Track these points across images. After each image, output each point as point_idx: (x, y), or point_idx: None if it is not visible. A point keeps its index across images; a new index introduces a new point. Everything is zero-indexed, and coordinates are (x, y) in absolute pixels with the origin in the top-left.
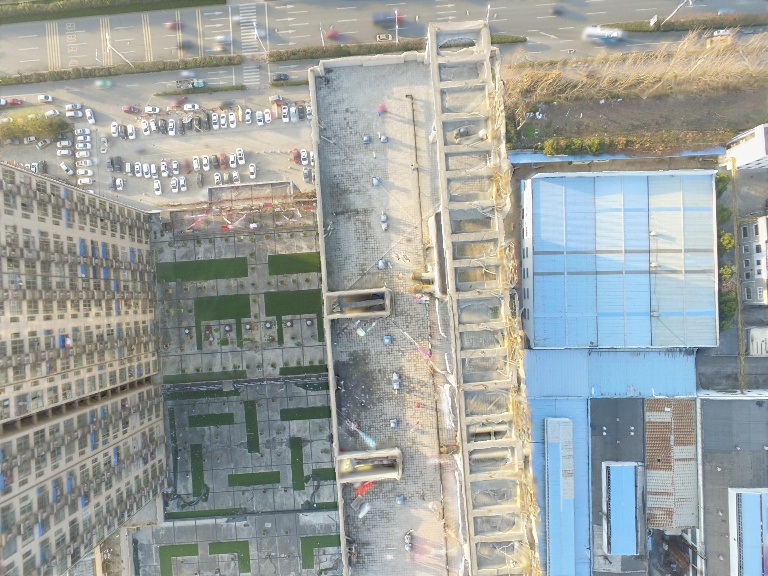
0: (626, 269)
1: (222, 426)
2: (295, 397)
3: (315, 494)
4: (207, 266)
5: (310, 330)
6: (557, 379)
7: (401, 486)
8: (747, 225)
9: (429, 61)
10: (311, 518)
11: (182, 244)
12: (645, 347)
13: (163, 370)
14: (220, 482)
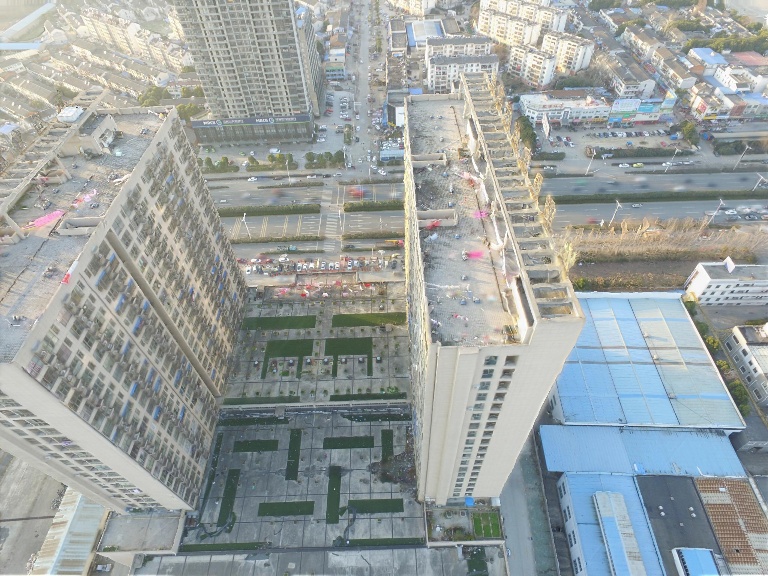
0: (632, 360)
1: (265, 452)
2: (340, 427)
3: (349, 529)
4: (284, 320)
5: (361, 367)
6: (595, 454)
7: (457, 231)
8: (728, 340)
9: (460, 97)
10: (342, 558)
11: (268, 305)
12: (674, 426)
13: (226, 394)
14: (249, 511)
